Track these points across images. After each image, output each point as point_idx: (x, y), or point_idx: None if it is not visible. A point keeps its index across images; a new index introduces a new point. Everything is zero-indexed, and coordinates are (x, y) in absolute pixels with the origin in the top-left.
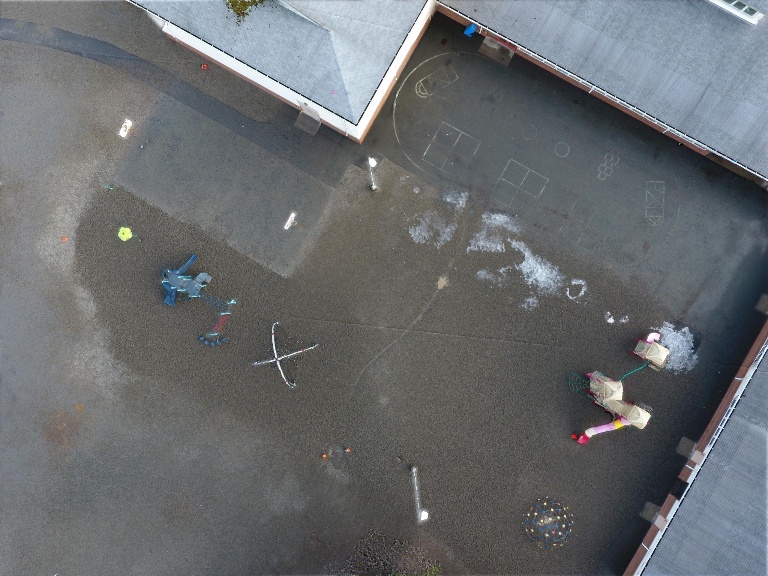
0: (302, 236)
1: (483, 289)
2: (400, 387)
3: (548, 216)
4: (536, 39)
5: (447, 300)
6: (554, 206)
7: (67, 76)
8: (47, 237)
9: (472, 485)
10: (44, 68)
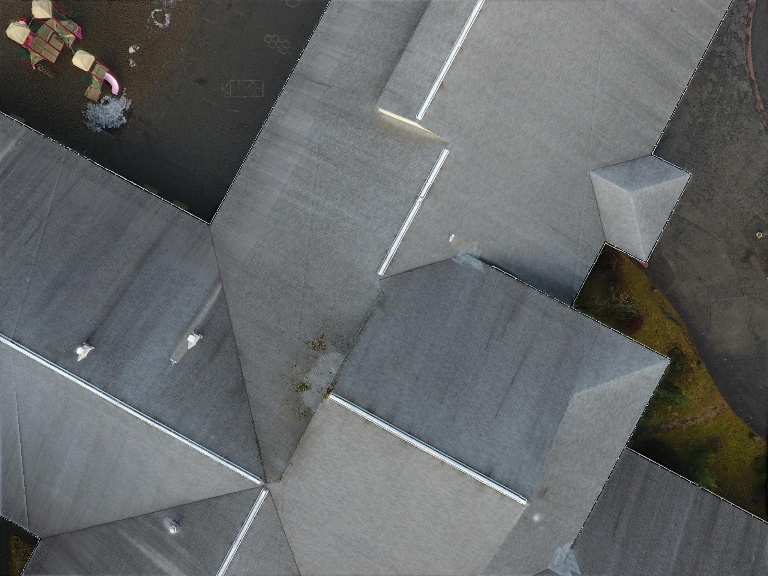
0: None
1: None
2: None
3: None
4: None
5: None
6: None
7: None
8: None
9: None
10: None
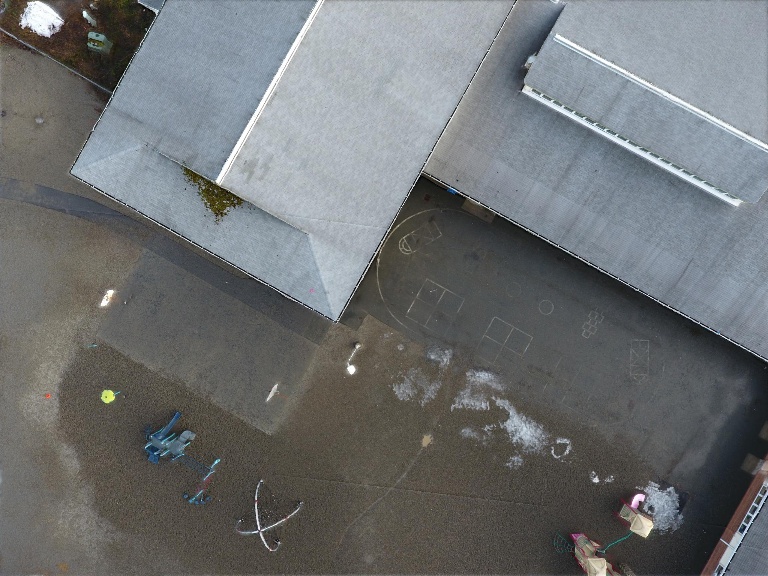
0: (286, 393)
1: (468, 447)
2: (385, 546)
3: (532, 374)
4: (518, 210)
5: (432, 458)
6: (538, 364)
7: (50, 233)
8: (30, 395)
9: None
10: (27, 225)
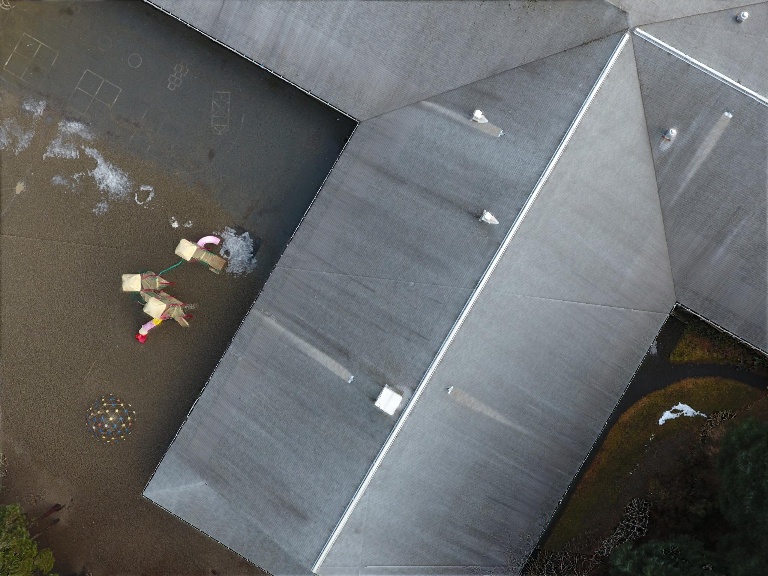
0: None
1: (57, 194)
2: None
3: (120, 124)
4: None
5: (23, 204)
6: (126, 115)
7: None
8: None
9: (42, 383)
10: None
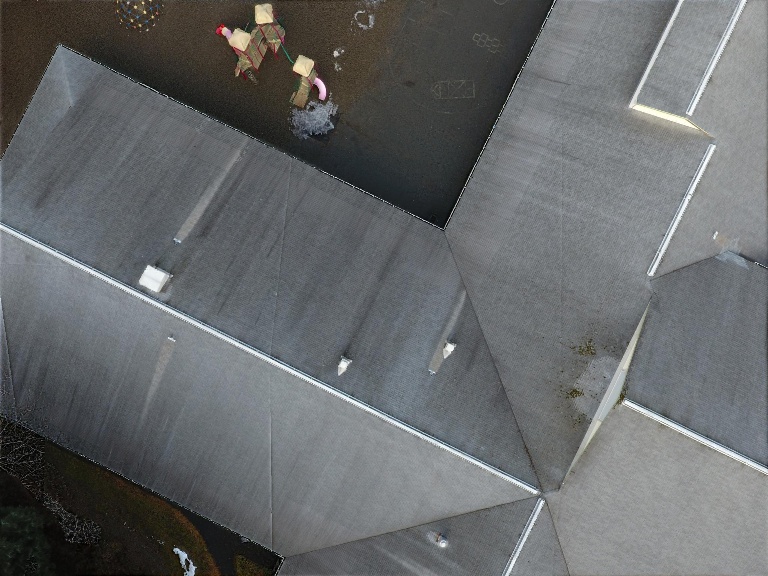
0: None
1: None
2: None
3: None
4: None
5: None
6: None
7: None
8: None
9: None
10: None
